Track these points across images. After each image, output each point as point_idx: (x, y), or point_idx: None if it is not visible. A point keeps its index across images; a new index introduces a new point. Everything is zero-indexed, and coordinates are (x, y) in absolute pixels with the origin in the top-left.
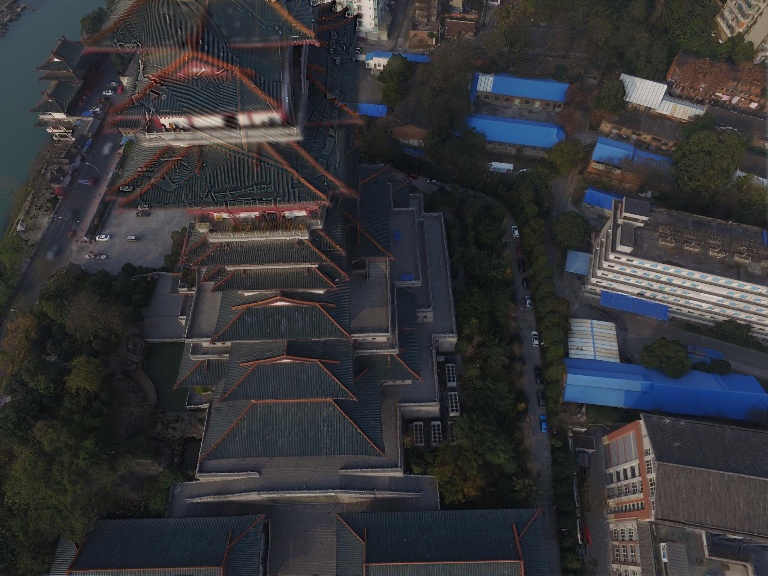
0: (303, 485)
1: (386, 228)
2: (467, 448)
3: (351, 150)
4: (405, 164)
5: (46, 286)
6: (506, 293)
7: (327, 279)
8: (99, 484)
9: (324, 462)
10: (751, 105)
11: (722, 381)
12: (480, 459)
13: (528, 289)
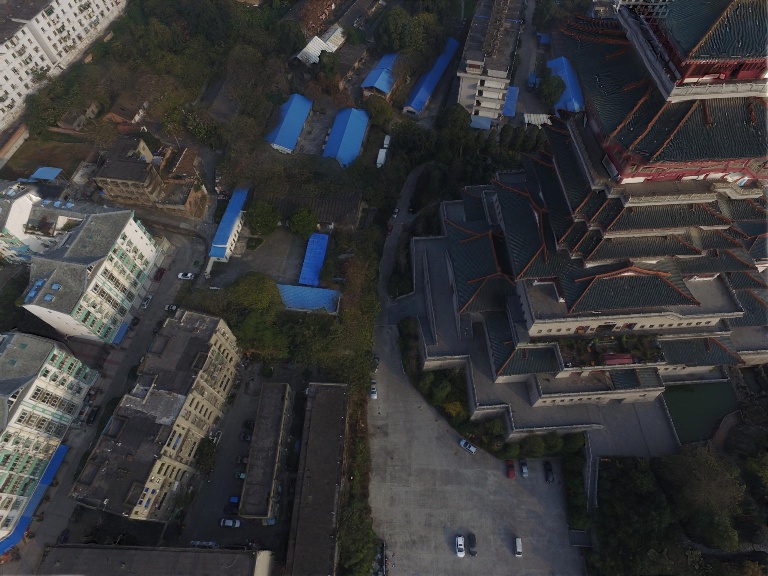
0: None
1: None
2: None
3: None
4: None
5: (697, 573)
6: None
7: None
8: None
9: None
10: (333, 7)
11: None
12: None
13: None
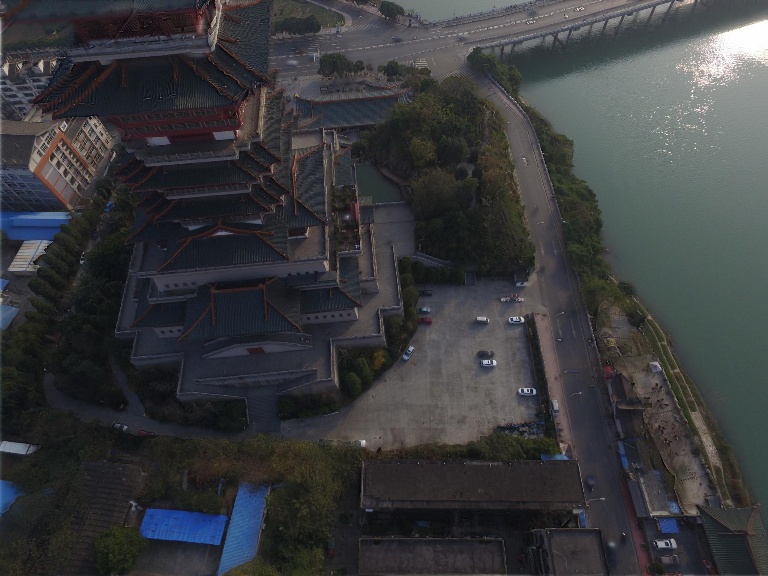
0: None
1: None
2: None
3: (146, 198)
4: None
5: None
6: (86, 259)
7: None
8: None
9: None
10: None
11: None
12: None
13: None
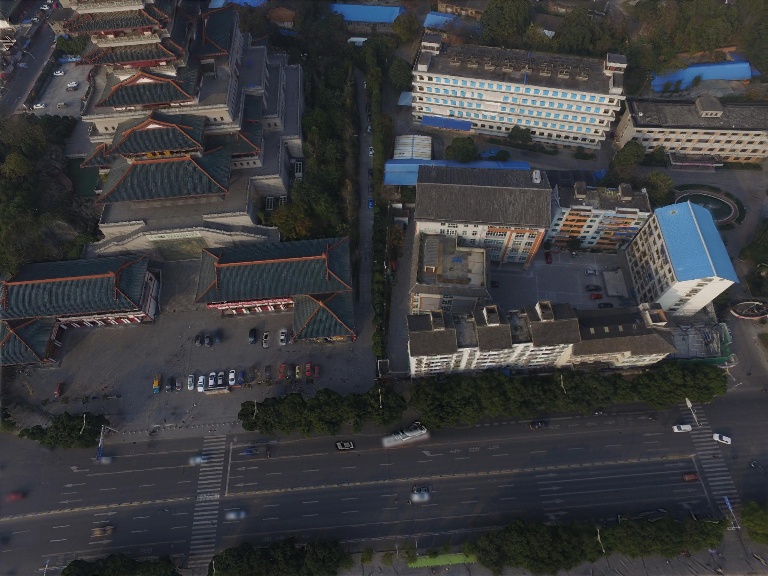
0: (177, 228)
1: (225, 38)
2: (296, 199)
3: None
4: (281, 42)
5: None
6: (342, 112)
7: (169, 51)
8: (29, 239)
9: (193, 214)
10: None
11: (501, 164)
12: (305, 205)
13: (371, 121)
